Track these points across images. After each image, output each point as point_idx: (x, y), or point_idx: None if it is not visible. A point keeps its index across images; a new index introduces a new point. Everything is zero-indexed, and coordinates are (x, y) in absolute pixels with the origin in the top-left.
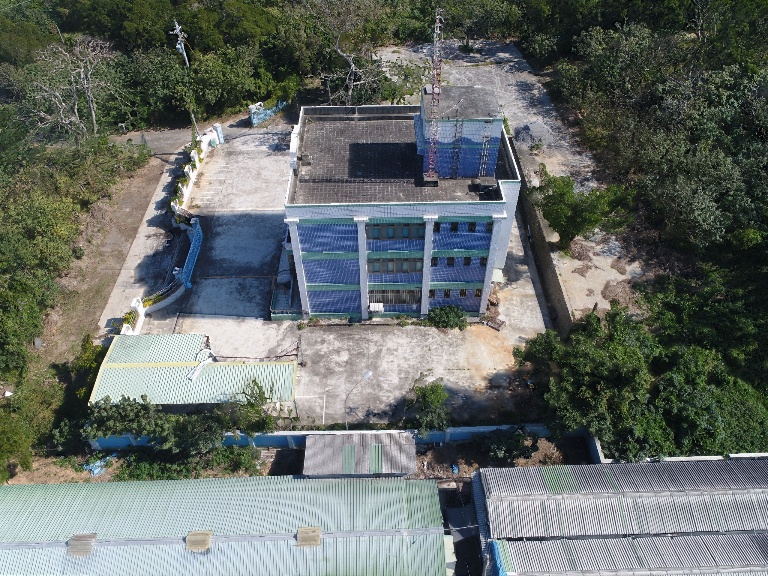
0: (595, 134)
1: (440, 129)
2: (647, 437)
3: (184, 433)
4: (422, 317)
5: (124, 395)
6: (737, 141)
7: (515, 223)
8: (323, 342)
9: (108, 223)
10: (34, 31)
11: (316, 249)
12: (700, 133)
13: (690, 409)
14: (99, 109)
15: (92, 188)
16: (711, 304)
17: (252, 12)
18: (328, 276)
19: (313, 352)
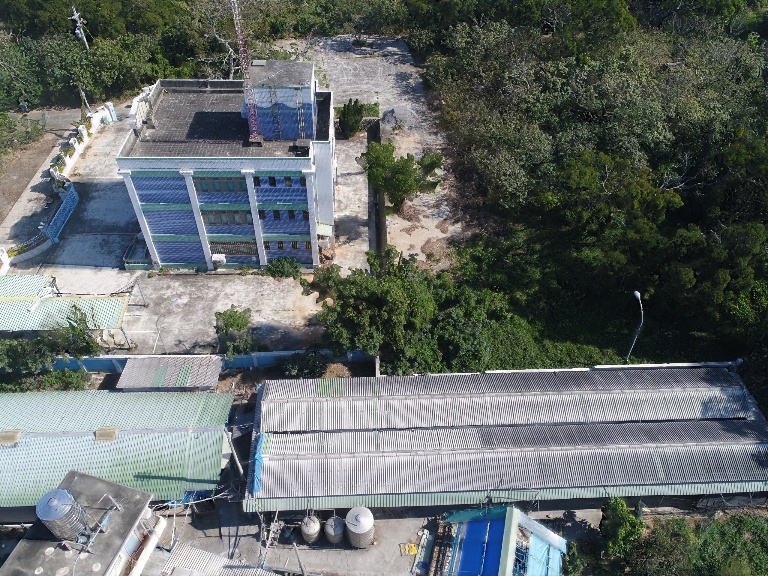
0: (452, 117)
1: (257, 95)
2: (417, 356)
3: (16, 355)
4: (262, 268)
5: None
6: None
7: (367, 192)
8: (168, 288)
9: None
10: None
11: (153, 201)
12: (532, 114)
13: (459, 335)
14: (4, 89)
15: None
16: (512, 257)
17: (160, 4)
18: (169, 227)
19: (157, 296)
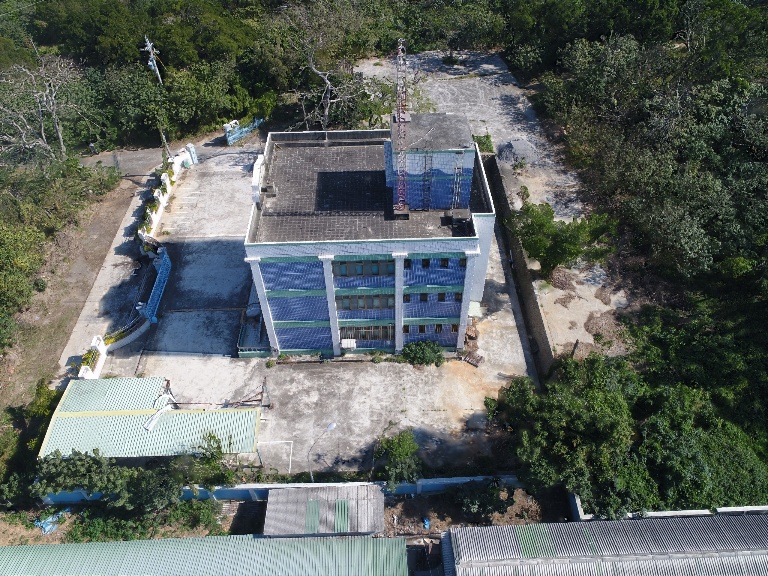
0: (580, 151)
1: (409, 161)
2: (629, 490)
3: (138, 489)
4: (397, 352)
5: (75, 448)
6: (727, 160)
7: (497, 248)
8: (292, 381)
9: (74, 251)
10: (6, 46)
11: (281, 287)
12: (688, 152)
13: (675, 458)
14: (70, 128)
15: (59, 213)
16: (699, 337)
17: (230, 25)
18: (296, 313)
19: (281, 392)
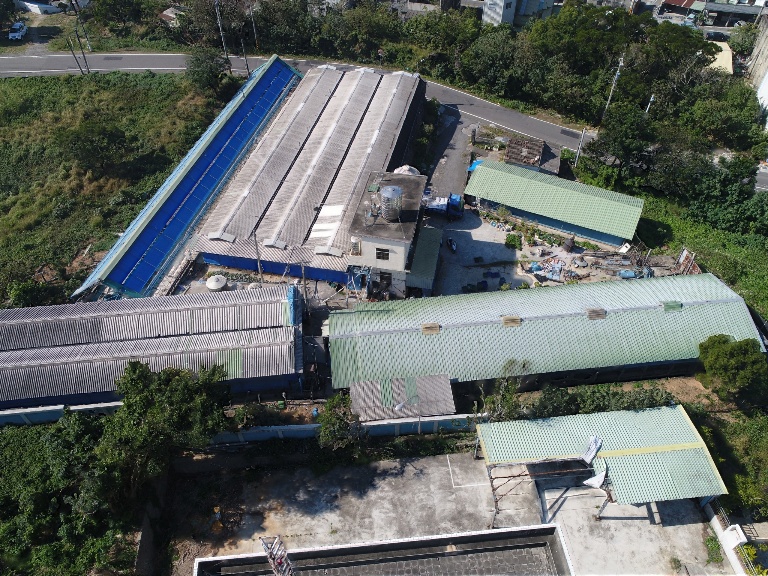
0: None
1: None
2: None
3: None
4: None
5: None
6: None
7: None
8: None
9: None
10: None
11: None
12: None
13: None
14: None
15: None
16: None
17: None
18: None
19: None
